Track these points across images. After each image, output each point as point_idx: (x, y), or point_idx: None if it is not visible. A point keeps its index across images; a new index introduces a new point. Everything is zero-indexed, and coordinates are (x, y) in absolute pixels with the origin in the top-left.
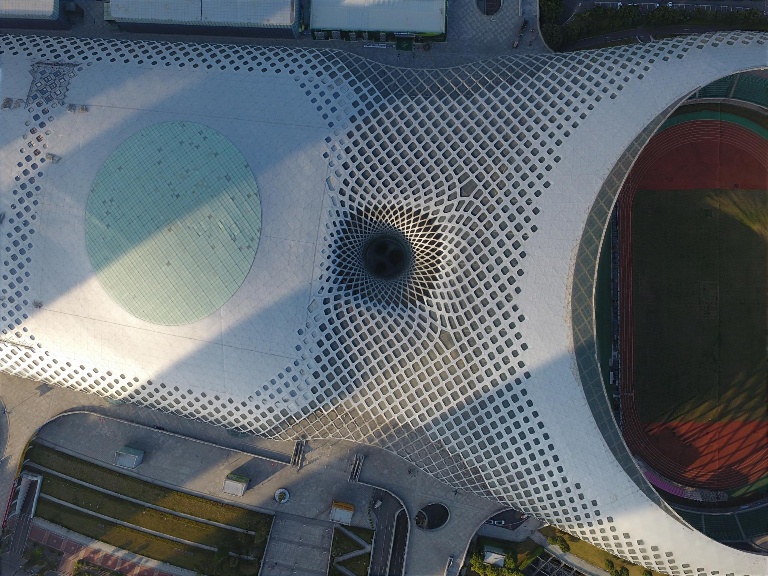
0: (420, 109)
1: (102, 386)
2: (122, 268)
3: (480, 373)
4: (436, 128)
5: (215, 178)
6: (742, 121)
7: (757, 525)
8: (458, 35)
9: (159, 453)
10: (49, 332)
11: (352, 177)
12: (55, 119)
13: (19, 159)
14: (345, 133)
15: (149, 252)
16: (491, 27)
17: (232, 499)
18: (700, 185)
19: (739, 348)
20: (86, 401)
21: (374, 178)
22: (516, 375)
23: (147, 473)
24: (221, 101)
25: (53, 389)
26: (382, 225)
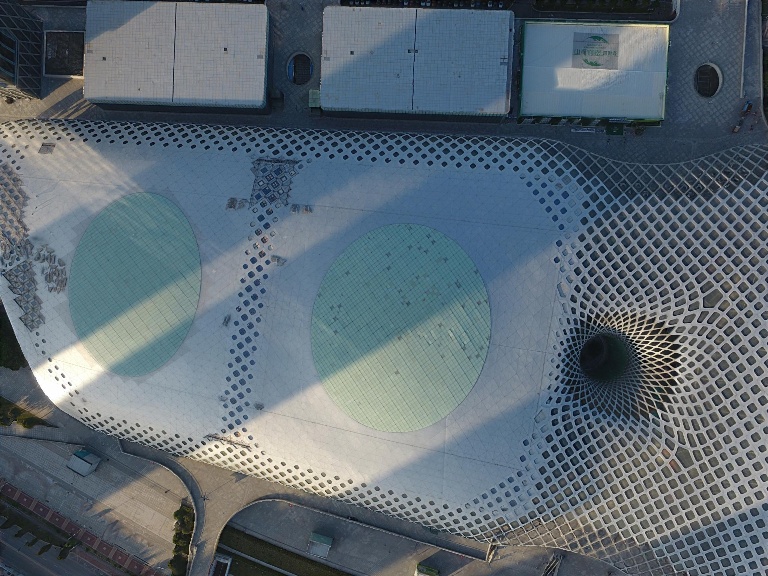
0: (655, 210)
1: (313, 485)
2: (349, 375)
3: (721, 495)
4: (674, 232)
5: (445, 285)
6: None
7: None
8: (673, 119)
9: (347, 540)
10: (268, 433)
11: (584, 283)
12: (279, 220)
13: (244, 261)
14: (576, 236)
15: (378, 360)
16: (709, 110)
17: None
18: None
19: None
20: (280, 489)
21: (607, 284)
22: (764, 500)
23: (335, 560)
24: (446, 201)
25: (248, 476)
26: (606, 329)
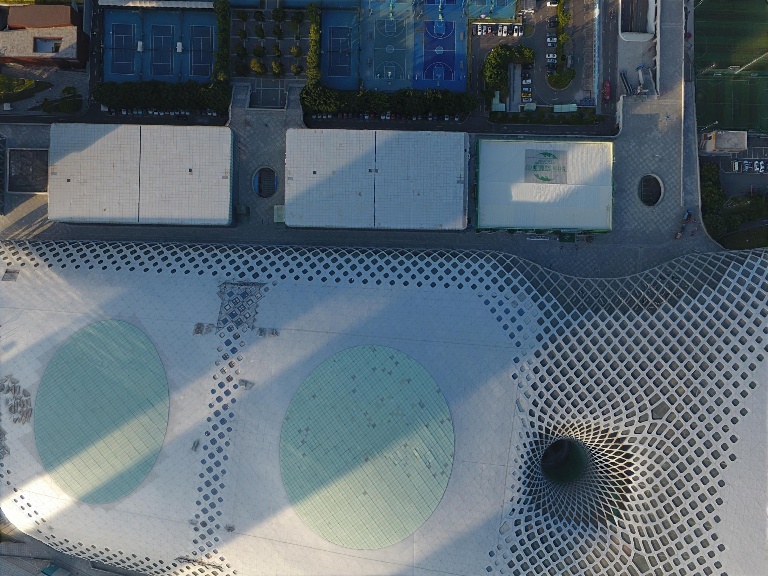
0: (605, 325)
1: None
2: (318, 496)
3: None
4: (623, 346)
5: (409, 406)
6: None
7: None
8: (620, 226)
9: None
10: (239, 554)
11: (541, 398)
12: (246, 344)
13: (212, 386)
14: (532, 352)
15: (346, 482)
16: (653, 218)
17: None
18: None
19: None
20: None
21: (563, 398)
22: None
23: None
24: (408, 322)
25: None
26: (565, 437)
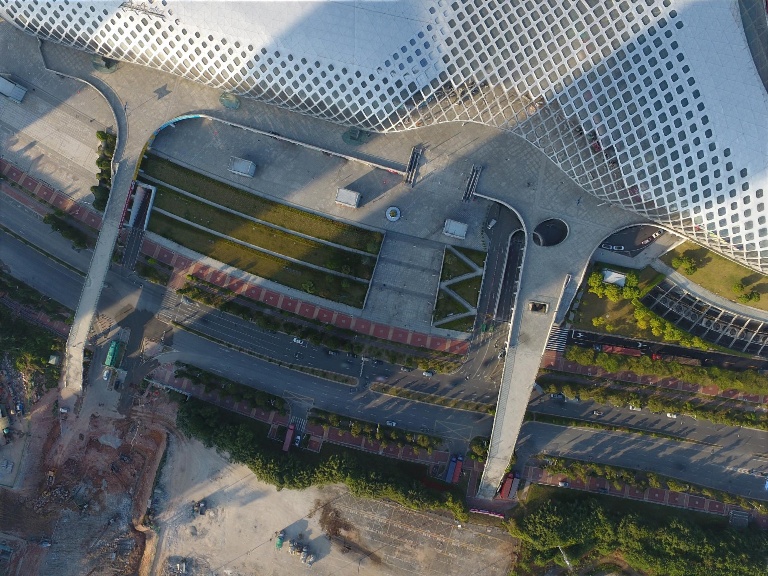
0: None
1: (228, 63)
2: None
3: (626, 30)
4: None
5: None
6: None
7: None
8: None
9: (271, 168)
10: None
11: None
12: None
13: None
14: None
15: None
16: None
17: (342, 216)
18: None
19: None
20: (203, 105)
21: None
22: (667, 27)
23: (258, 187)
24: None
25: (171, 92)
26: None
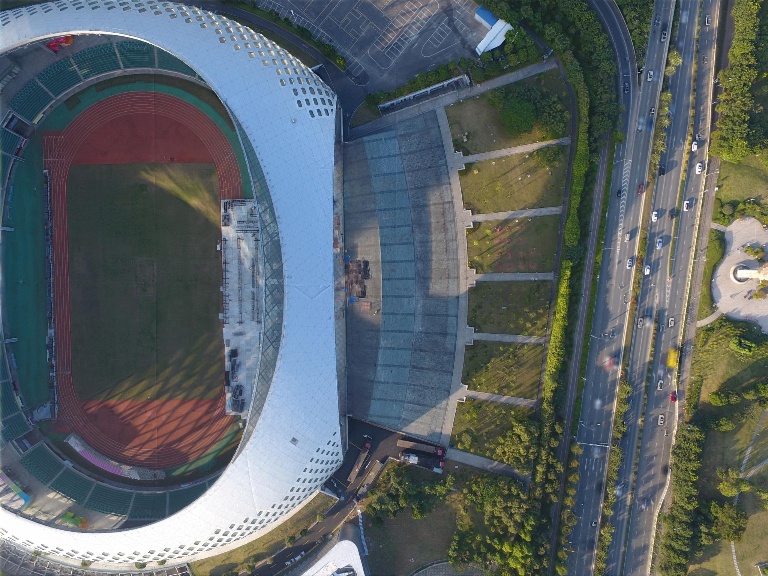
0: None
1: None
2: None
3: None
4: None
5: None
6: (177, 92)
7: (184, 503)
8: None
9: None
10: None
11: None
12: None
13: None
14: None
15: None
16: None
17: None
18: (135, 159)
19: (177, 326)
20: None
21: None
22: None
23: None
24: None
25: None
26: None
